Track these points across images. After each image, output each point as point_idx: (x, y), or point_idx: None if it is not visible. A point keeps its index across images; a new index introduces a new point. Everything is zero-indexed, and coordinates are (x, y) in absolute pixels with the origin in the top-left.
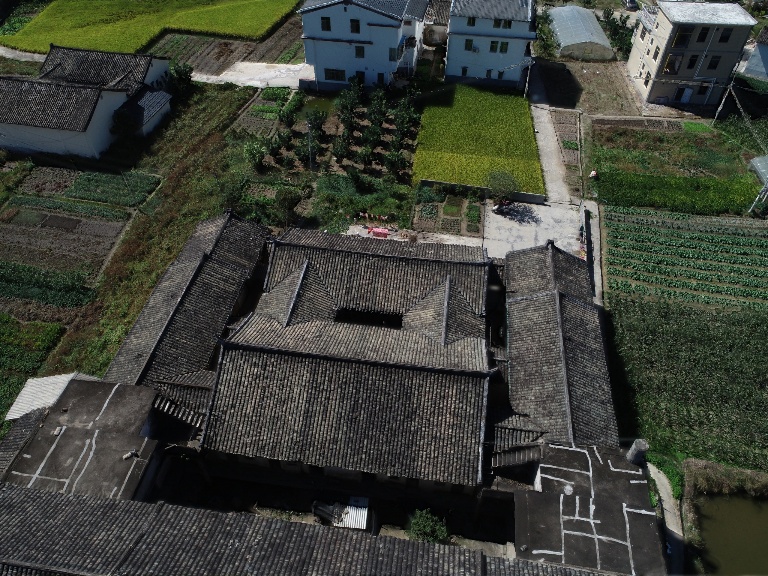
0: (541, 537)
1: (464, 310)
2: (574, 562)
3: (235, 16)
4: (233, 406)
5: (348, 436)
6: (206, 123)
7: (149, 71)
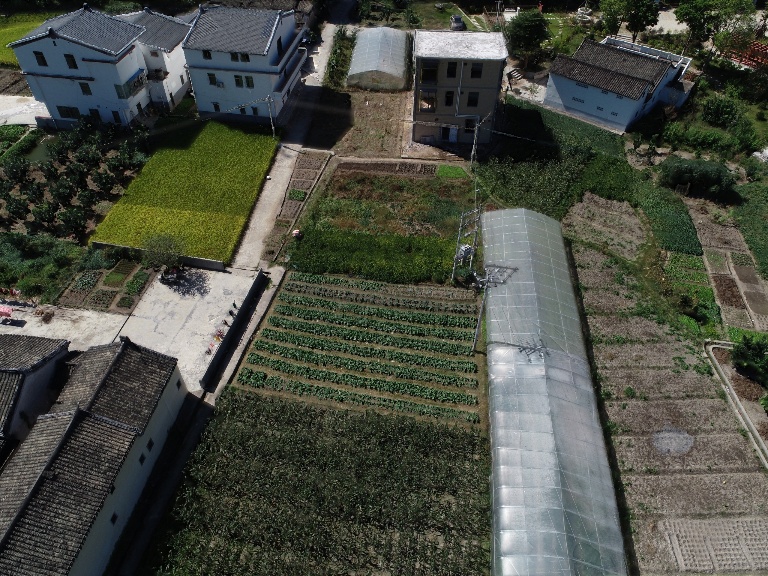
0: None
1: None
2: None
3: None
4: None
5: None
6: None
7: None
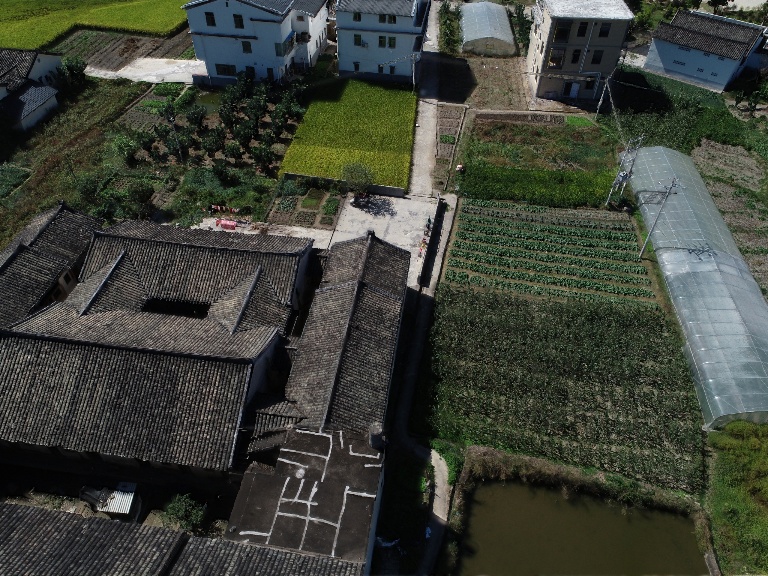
0: (253, 519)
1: (269, 300)
2: (277, 543)
3: (148, 12)
4: (3, 392)
5: (110, 422)
6: (90, 118)
7: (35, 66)
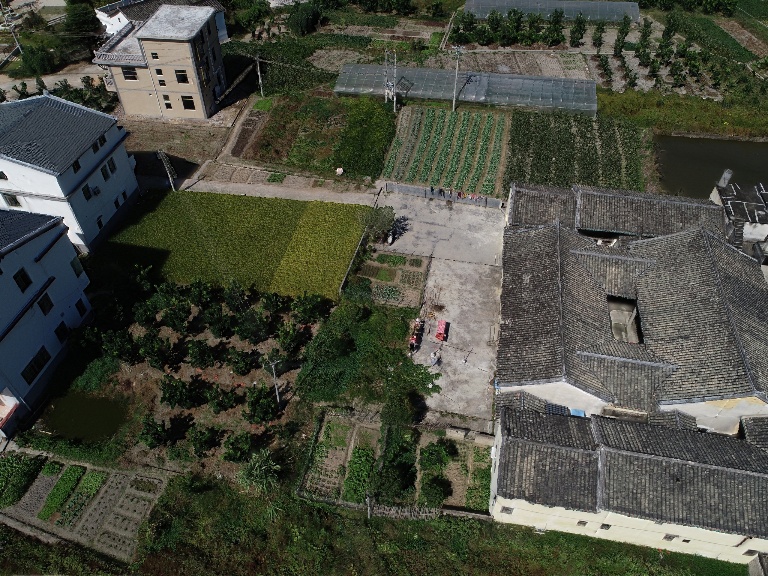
0: None
1: None
2: None
3: None
4: None
5: None
6: None
7: None
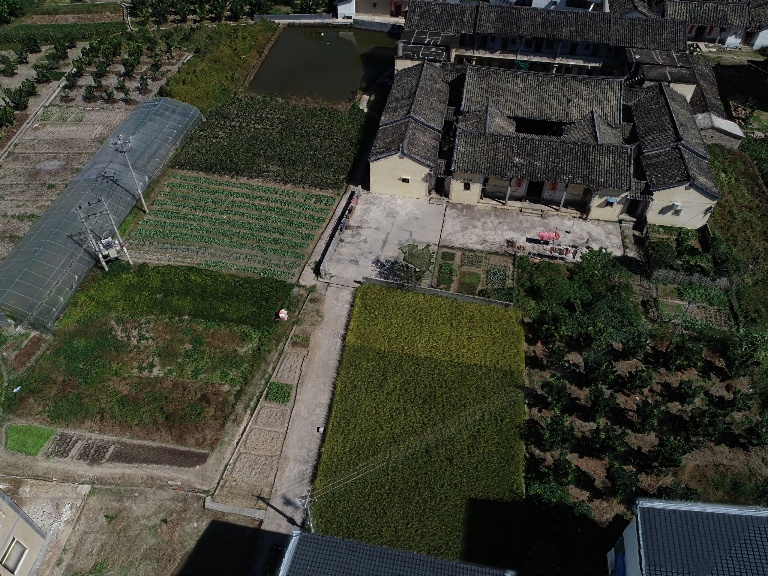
0: None
1: None
2: None
3: None
4: None
5: None
6: None
7: None
